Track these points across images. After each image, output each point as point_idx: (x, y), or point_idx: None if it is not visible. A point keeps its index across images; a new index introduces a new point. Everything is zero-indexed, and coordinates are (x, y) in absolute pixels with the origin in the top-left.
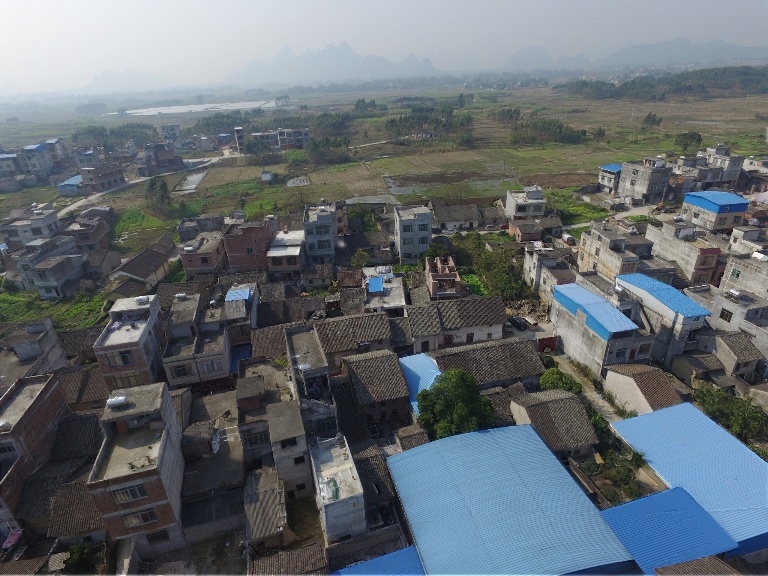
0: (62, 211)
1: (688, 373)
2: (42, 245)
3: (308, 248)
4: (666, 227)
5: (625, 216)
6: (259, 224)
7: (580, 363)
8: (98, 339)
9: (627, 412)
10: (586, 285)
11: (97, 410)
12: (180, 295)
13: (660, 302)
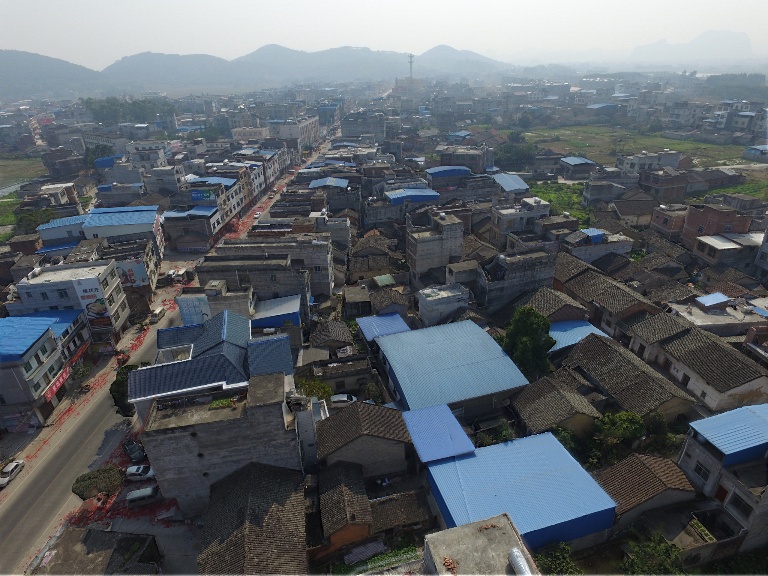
0: (713, 167)
1: None
2: (610, 172)
3: (759, 256)
4: None
5: None
6: (724, 209)
7: None
8: (500, 206)
9: None
10: None
11: (474, 237)
12: (566, 213)
13: None
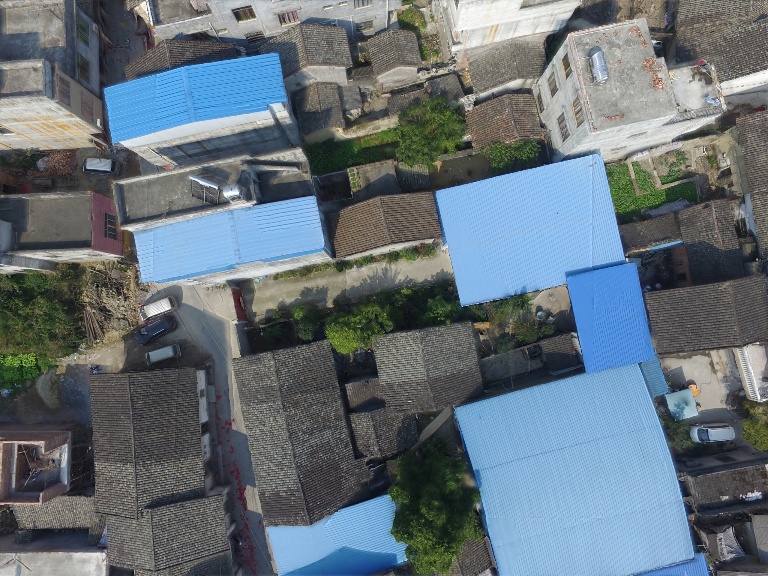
0: None
1: (332, 133)
2: None
3: None
4: None
5: None
6: None
7: (290, 270)
8: None
9: (396, 251)
10: (162, 224)
11: None
12: None
13: (234, 117)
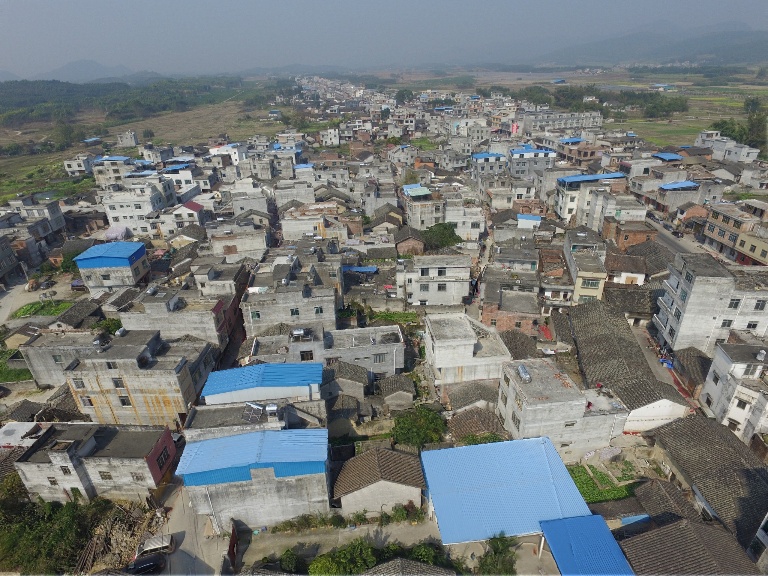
0: None
1: (347, 427)
2: None
3: None
4: (150, 306)
5: (7, 315)
6: None
7: (289, 521)
8: None
9: (388, 513)
10: (212, 434)
11: None
12: None
13: (285, 387)
